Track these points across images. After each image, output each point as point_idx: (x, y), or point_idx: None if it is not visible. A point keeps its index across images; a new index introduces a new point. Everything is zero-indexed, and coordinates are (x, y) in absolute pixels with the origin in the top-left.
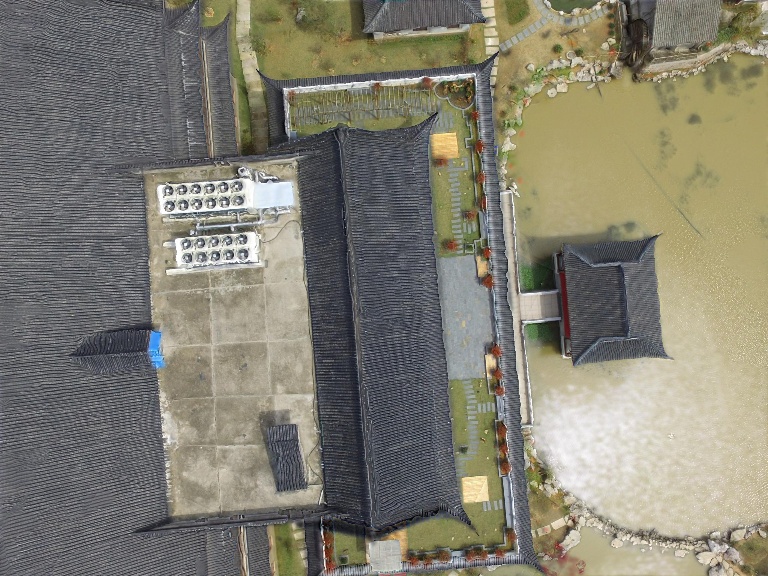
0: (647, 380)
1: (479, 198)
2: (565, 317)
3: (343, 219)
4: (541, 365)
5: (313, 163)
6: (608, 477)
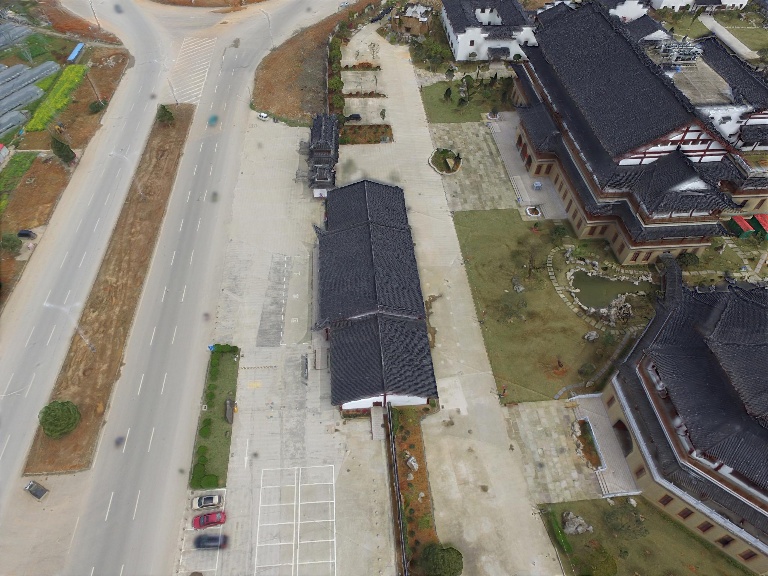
0: None
1: None
2: None
3: None
4: None
5: None
6: None
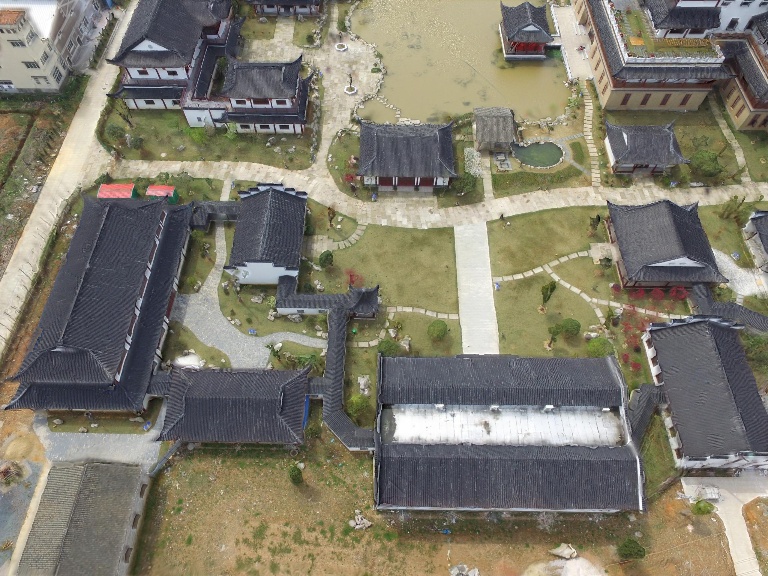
0: None
1: None
2: None
3: None
4: None
5: None
6: (505, 0)
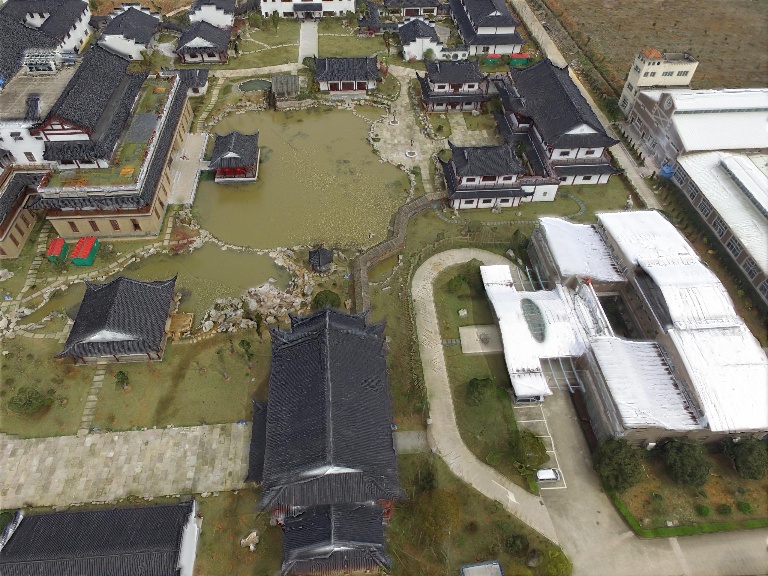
0: (262, 197)
1: None
2: None
3: None
4: (206, 187)
5: None
6: None
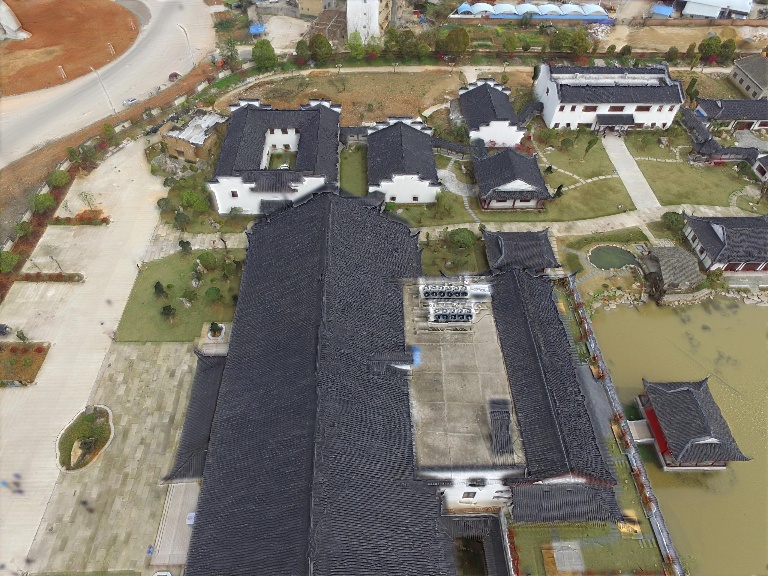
0: (740, 498)
1: (584, 335)
2: (657, 438)
3: (523, 308)
4: (648, 477)
5: (499, 287)
6: None
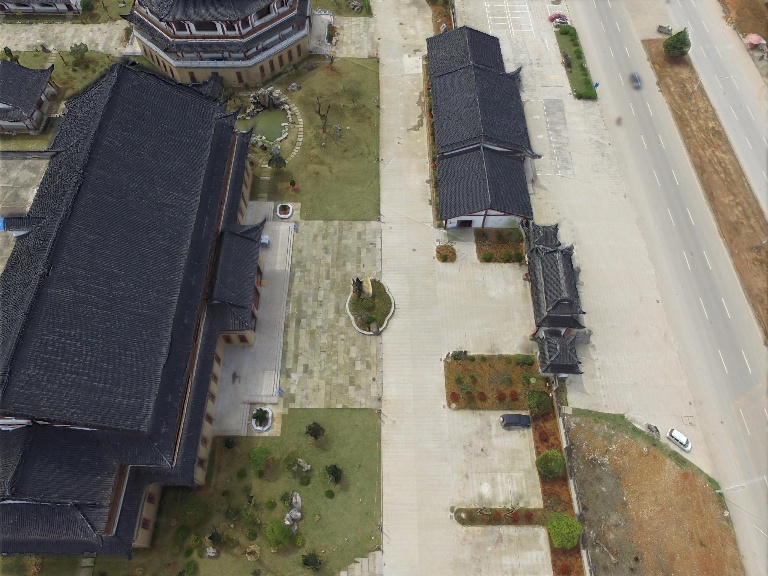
0: None
1: None
2: None
3: None
4: None
5: None
6: None
